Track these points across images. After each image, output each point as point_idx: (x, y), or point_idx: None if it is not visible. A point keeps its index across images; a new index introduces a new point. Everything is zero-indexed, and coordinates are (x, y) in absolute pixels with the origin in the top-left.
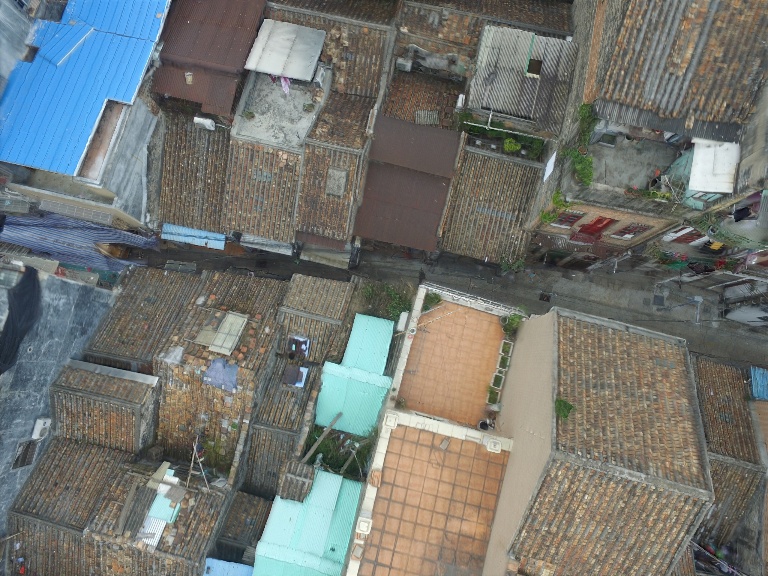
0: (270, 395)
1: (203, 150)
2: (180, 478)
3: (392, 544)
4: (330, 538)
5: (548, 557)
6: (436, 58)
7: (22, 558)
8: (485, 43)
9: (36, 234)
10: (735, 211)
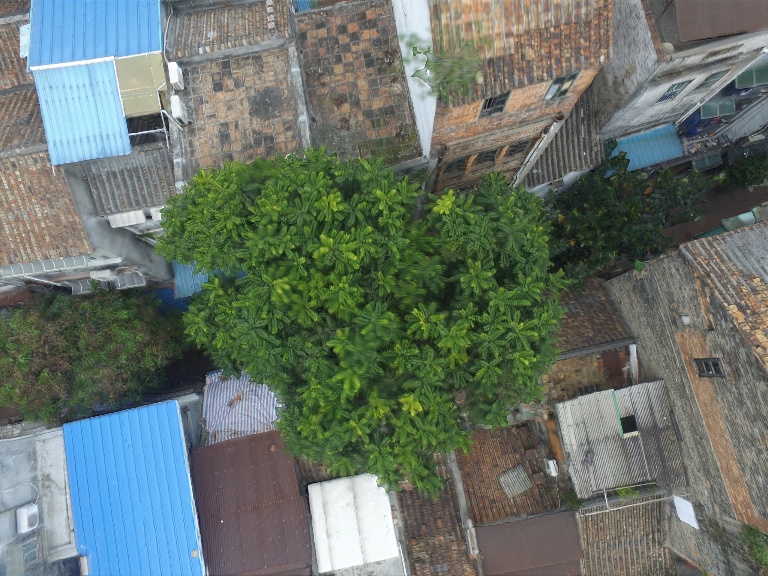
0: None
1: None
2: None
3: None
4: None
5: None
6: None
7: None
8: (566, 422)
9: None
10: None
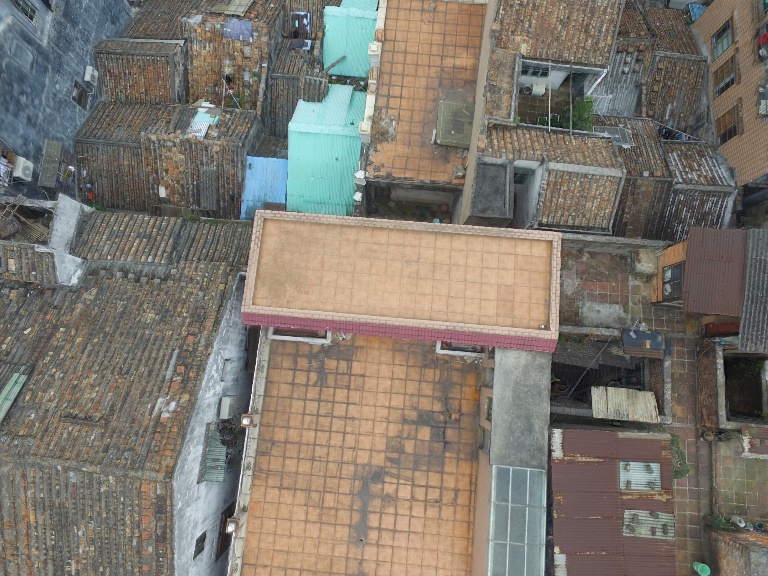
0: (282, 59)
1: None
2: (215, 105)
3: (400, 82)
4: (349, 117)
5: (524, 33)
6: None
7: (89, 185)
8: None
9: None
10: None
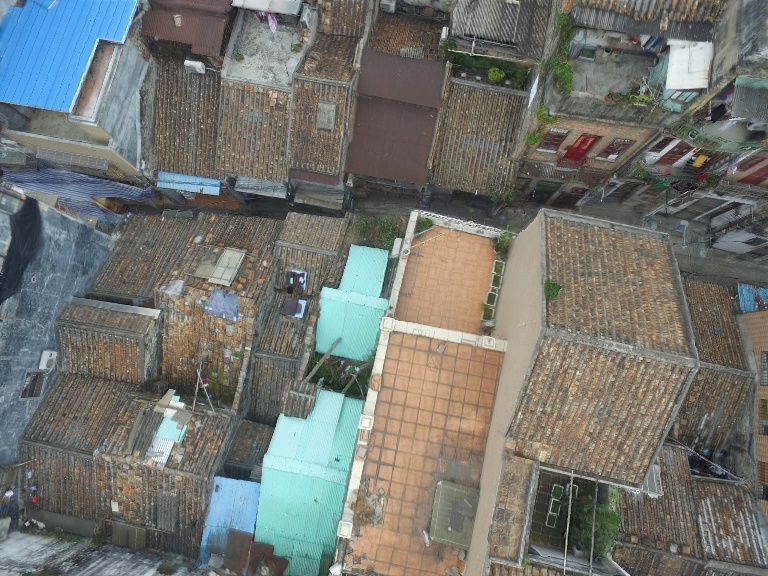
0: (270, 326)
1: (195, 95)
2: (186, 403)
3: (394, 444)
4: (334, 449)
5: (544, 439)
6: None
7: (34, 487)
8: None
9: None
10: (711, 110)
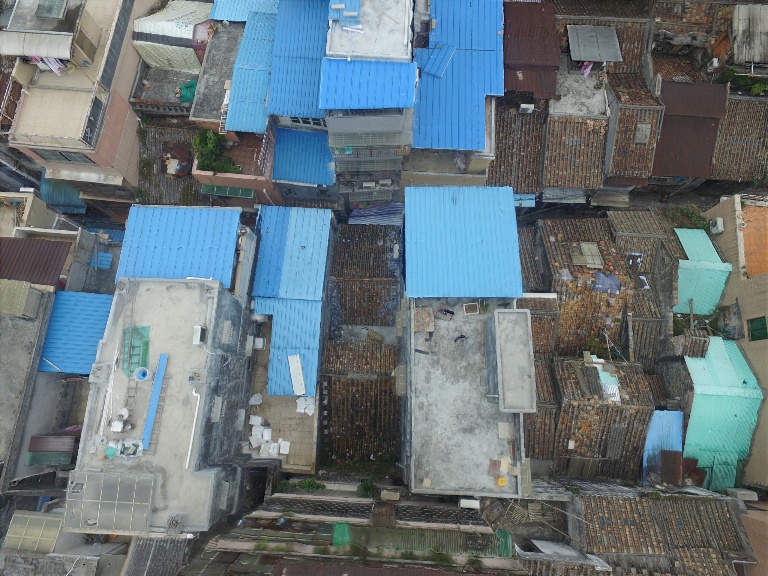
0: None
1: (517, 131)
2: (604, 359)
3: None
4: (739, 375)
5: None
6: (681, 37)
7: None
8: (738, 17)
9: (371, 222)
10: None
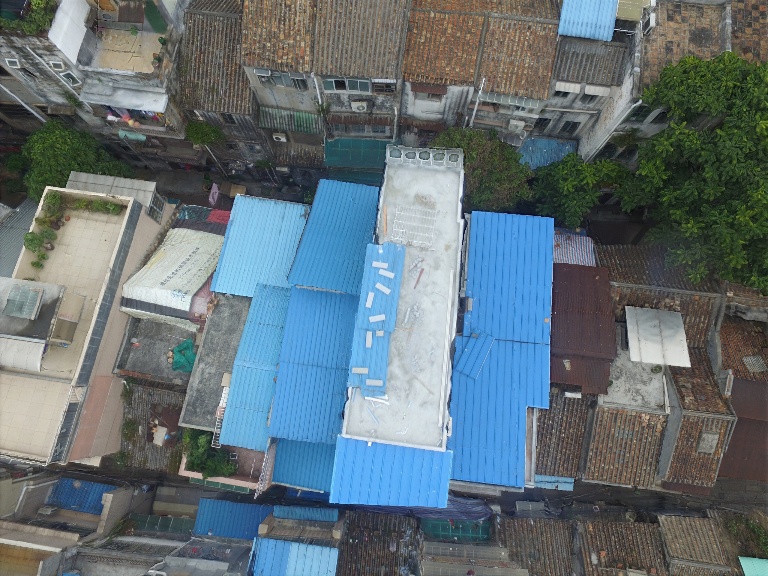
0: None
1: (558, 410)
2: None
3: None
4: None
5: None
6: (756, 312)
7: None
8: None
9: None
10: None
